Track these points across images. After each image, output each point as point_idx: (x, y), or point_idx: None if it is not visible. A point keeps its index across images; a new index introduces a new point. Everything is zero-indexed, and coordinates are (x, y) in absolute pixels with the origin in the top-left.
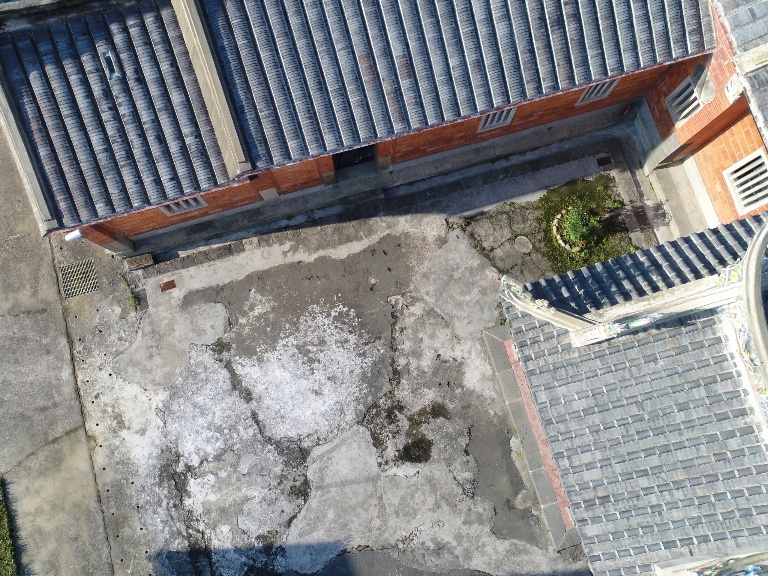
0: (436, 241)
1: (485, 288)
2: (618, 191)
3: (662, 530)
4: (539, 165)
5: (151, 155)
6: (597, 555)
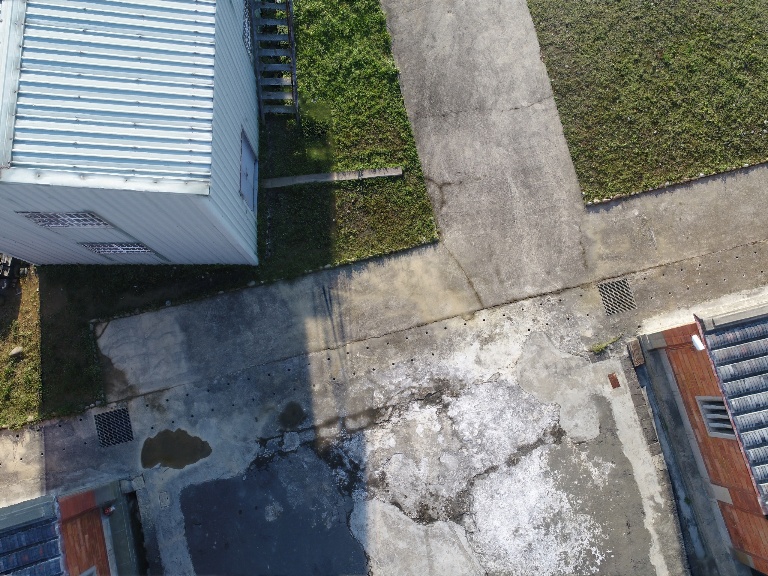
0: None
1: None
2: None
3: None
4: None
5: None
6: None
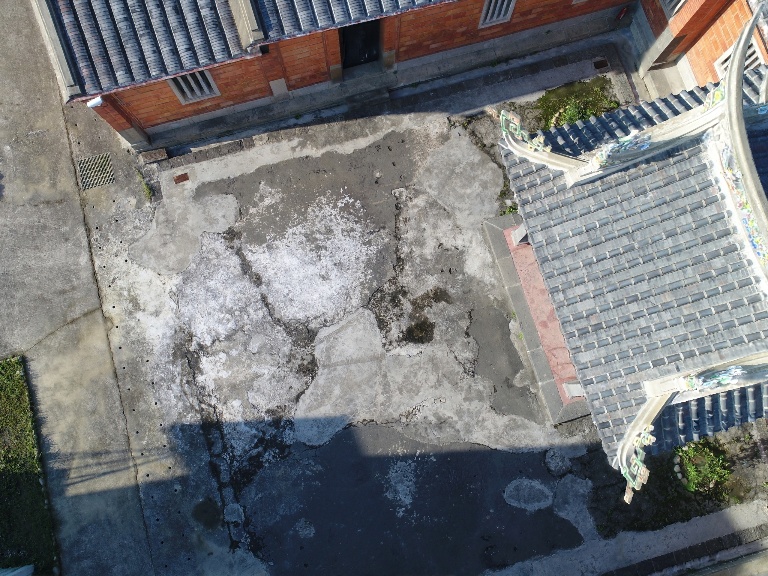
0: (439, 138)
1: (486, 182)
2: (614, 92)
3: (651, 349)
4: (538, 68)
5: (168, 26)
6: (590, 379)
